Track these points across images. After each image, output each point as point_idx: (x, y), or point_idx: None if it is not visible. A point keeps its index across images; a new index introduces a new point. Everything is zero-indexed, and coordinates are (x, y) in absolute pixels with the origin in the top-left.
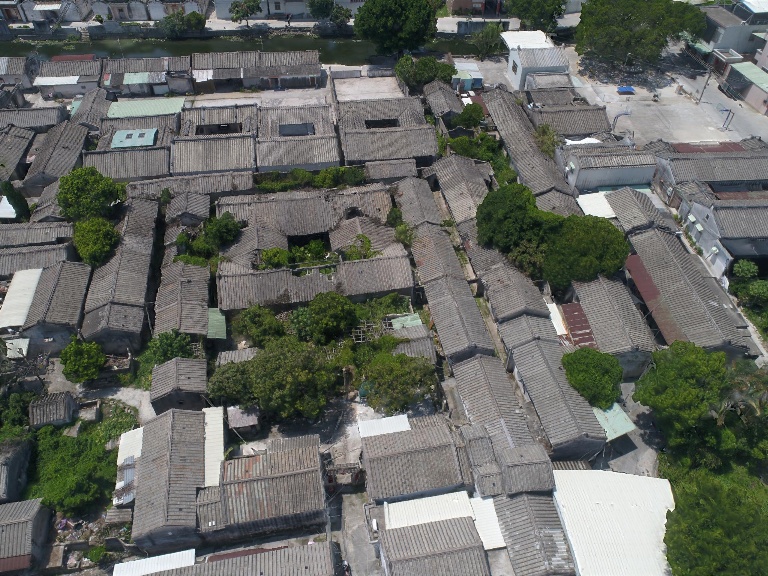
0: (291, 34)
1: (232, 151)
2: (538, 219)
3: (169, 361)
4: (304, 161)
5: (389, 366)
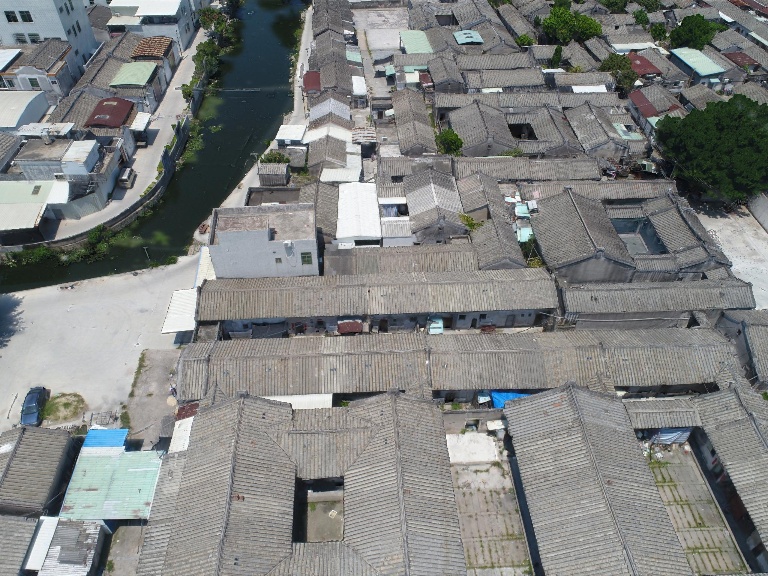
0: (226, 28)
1: (484, 8)
2: None
3: (648, 16)
4: None
5: None
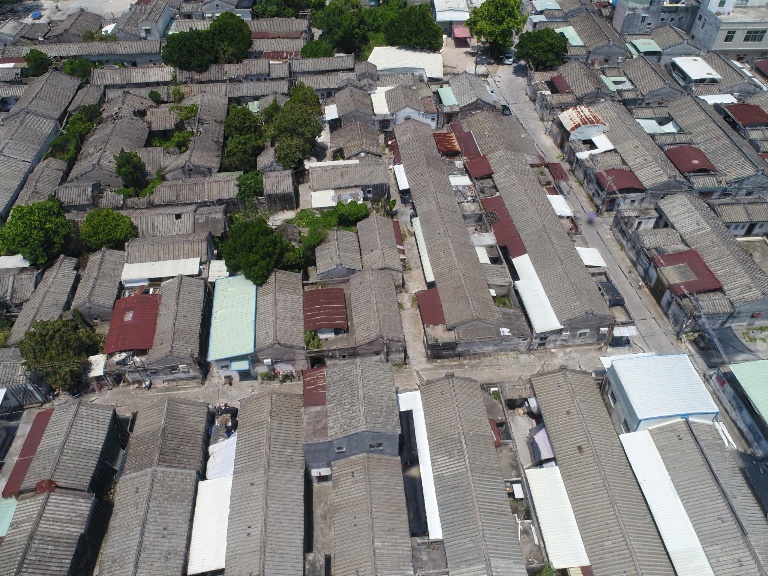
0: None
1: None
2: (212, 30)
3: (264, 181)
4: (43, 137)
5: (302, 94)
